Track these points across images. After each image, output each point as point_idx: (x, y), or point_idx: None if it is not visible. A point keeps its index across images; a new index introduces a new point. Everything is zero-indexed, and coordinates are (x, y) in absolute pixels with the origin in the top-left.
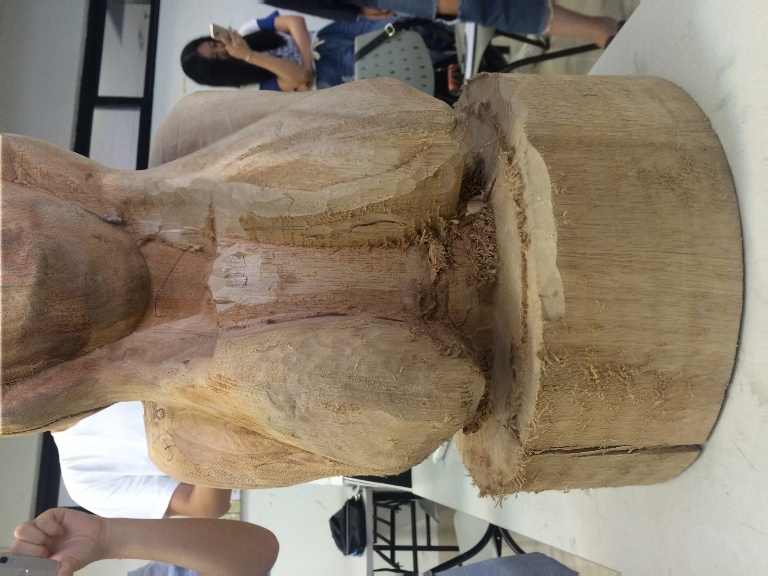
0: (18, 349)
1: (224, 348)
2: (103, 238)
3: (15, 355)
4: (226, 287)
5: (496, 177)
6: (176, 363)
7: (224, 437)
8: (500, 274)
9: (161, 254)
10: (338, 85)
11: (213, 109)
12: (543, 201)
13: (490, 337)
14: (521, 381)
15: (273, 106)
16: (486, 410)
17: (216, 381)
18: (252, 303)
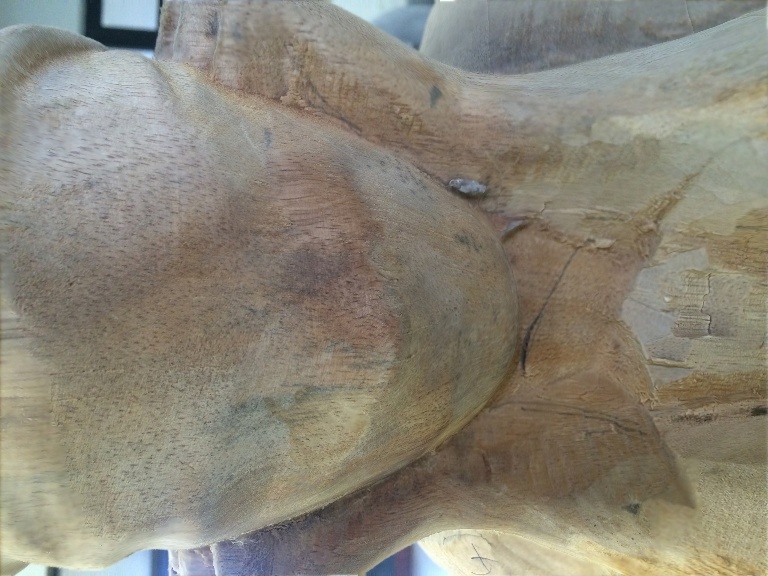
0: (323, 492)
1: (718, 490)
2: (471, 240)
3: (313, 501)
4: (675, 336)
5: None
6: (610, 507)
7: (602, 571)
8: None
9: (538, 255)
10: None
11: None
12: None
13: None
14: None
15: None
16: None
17: (717, 568)
18: (724, 371)
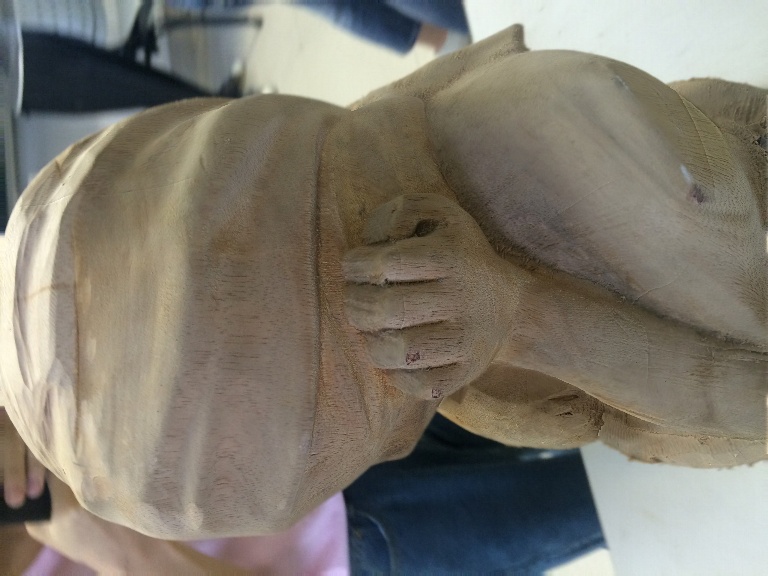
0: None
1: (472, 402)
2: None
3: None
4: None
5: None
6: None
7: None
8: None
9: None
10: (767, 392)
11: (673, 258)
12: (734, 459)
13: None
14: (608, 415)
15: (717, 309)
16: None
17: None
18: None
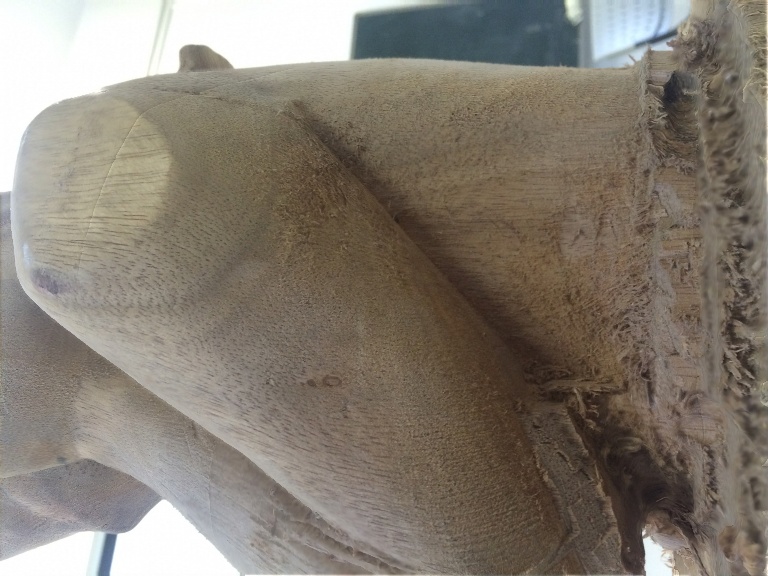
0: None
1: None
2: None
3: None
4: None
5: None
6: None
7: None
8: None
9: None
10: None
11: None
12: None
13: None
14: None
15: None
16: None
17: None
18: None
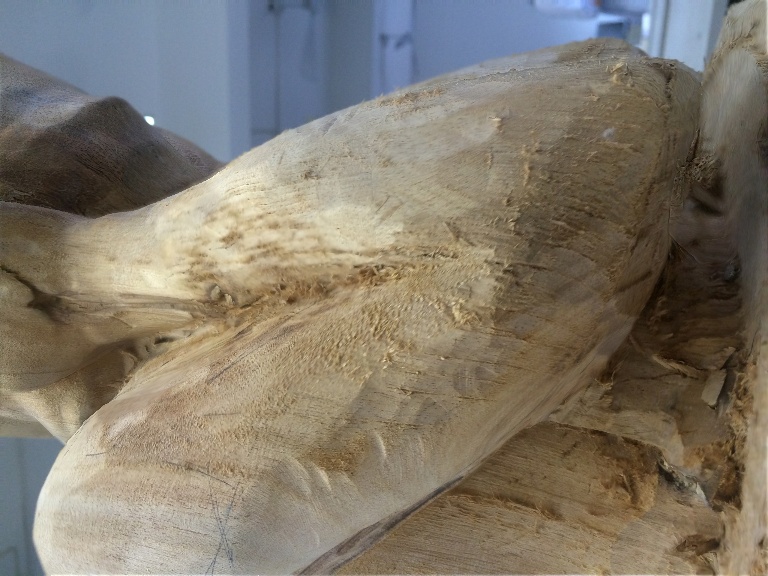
0: (22, 153)
1: None
2: None
3: (13, 159)
4: None
5: (699, 129)
6: None
7: (186, 370)
8: (723, 161)
9: None
10: None
11: None
12: None
13: (724, 252)
14: None
15: None
16: (744, 375)
17: None
18: None
